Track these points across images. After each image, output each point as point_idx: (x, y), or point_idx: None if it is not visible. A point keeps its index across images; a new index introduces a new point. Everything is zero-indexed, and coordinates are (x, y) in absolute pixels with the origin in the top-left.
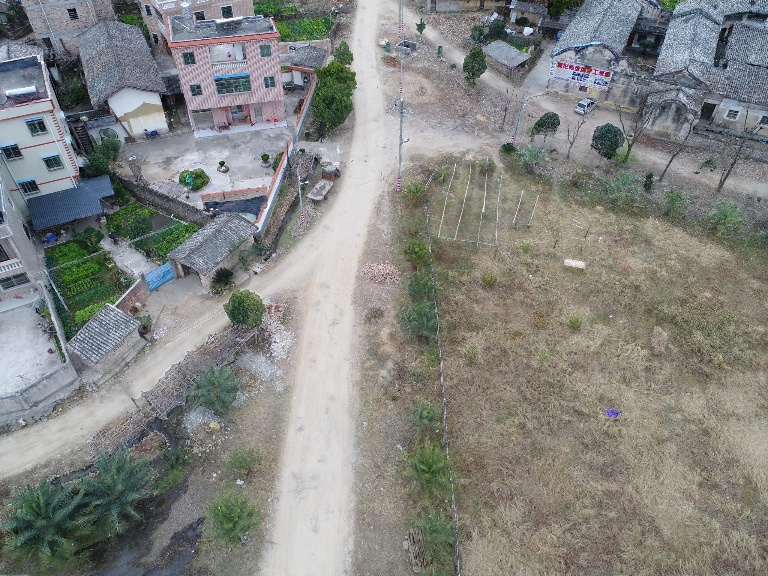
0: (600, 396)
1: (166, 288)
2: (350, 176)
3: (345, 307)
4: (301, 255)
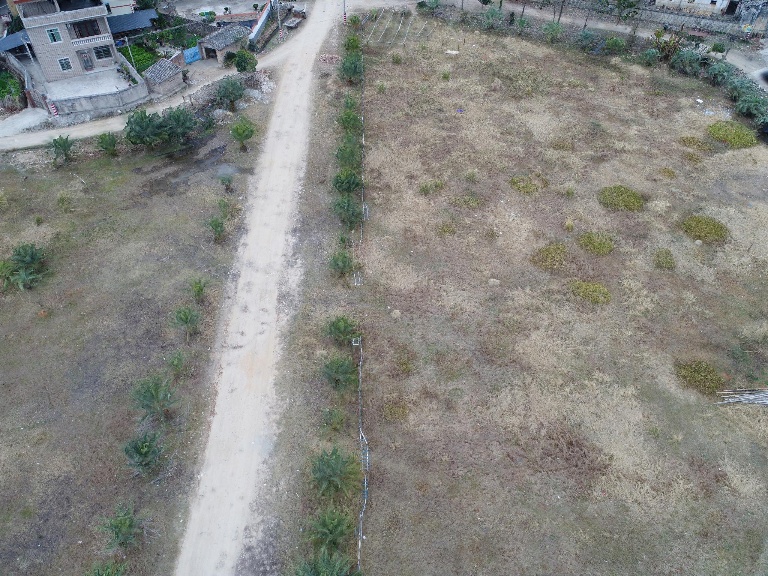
0: (454, 104)
1: (196, 64)
2: (313, 18)
3: (307, 73)
4: (280, 52)
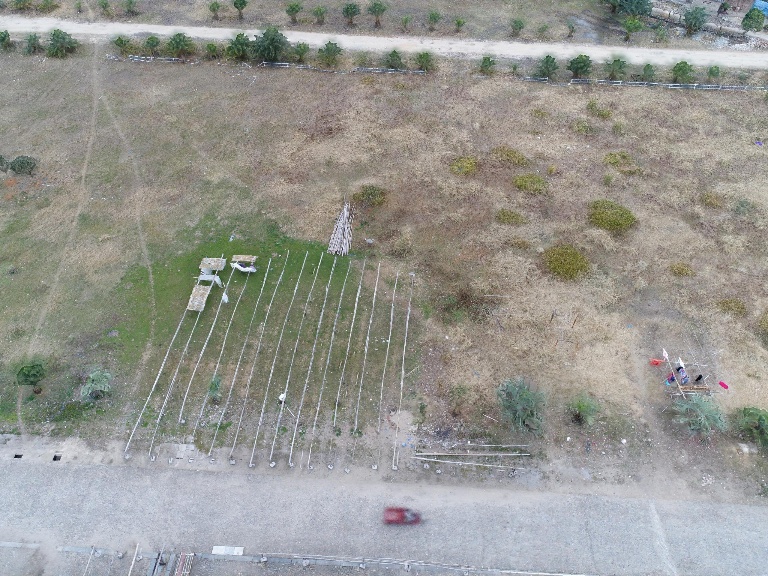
0: None
1: None
2: None
3: None
4: None
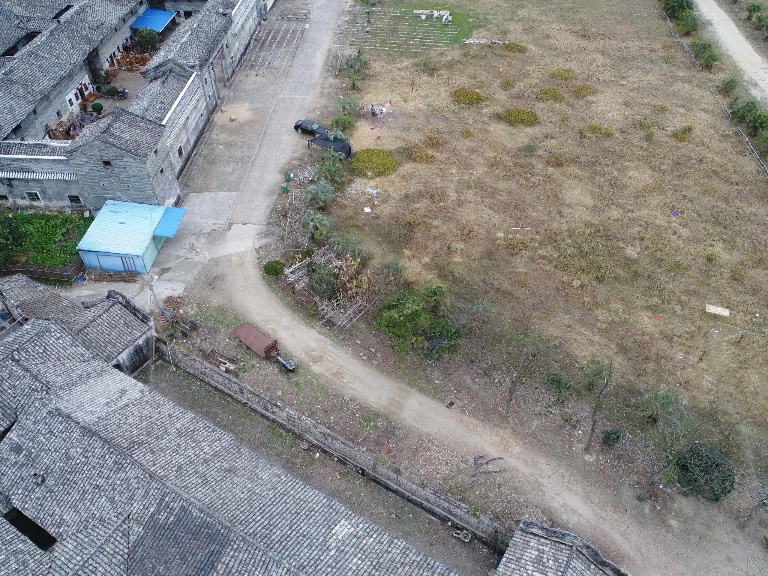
0: None
1: None
2: None
3: None
4: None
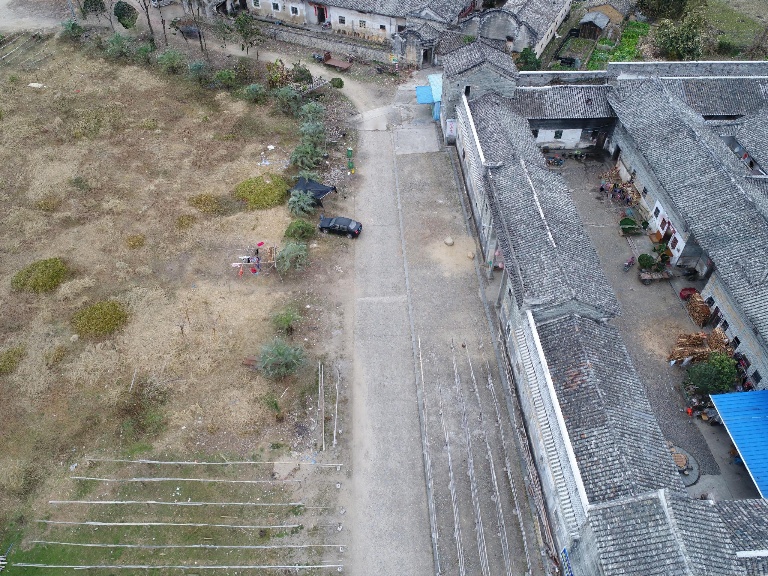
0: None
1: None
2: None
3: None
4: None
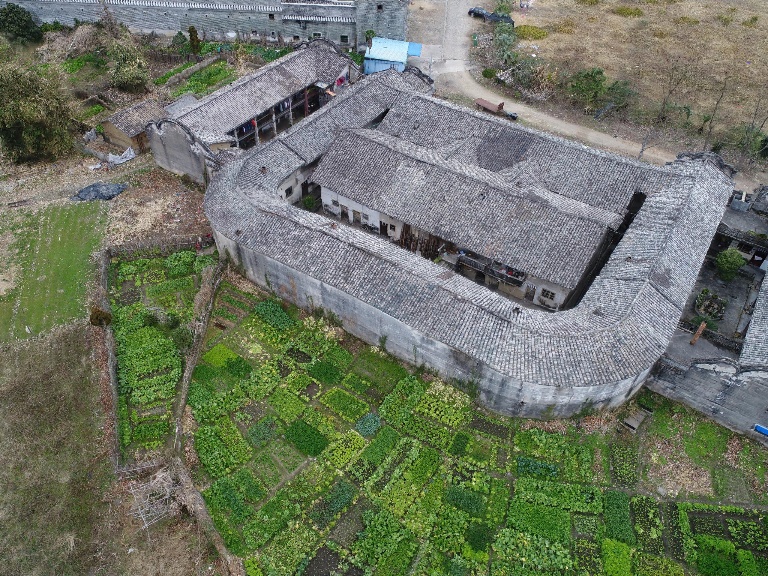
0: None
1: None
2: None
3: None
4: None
